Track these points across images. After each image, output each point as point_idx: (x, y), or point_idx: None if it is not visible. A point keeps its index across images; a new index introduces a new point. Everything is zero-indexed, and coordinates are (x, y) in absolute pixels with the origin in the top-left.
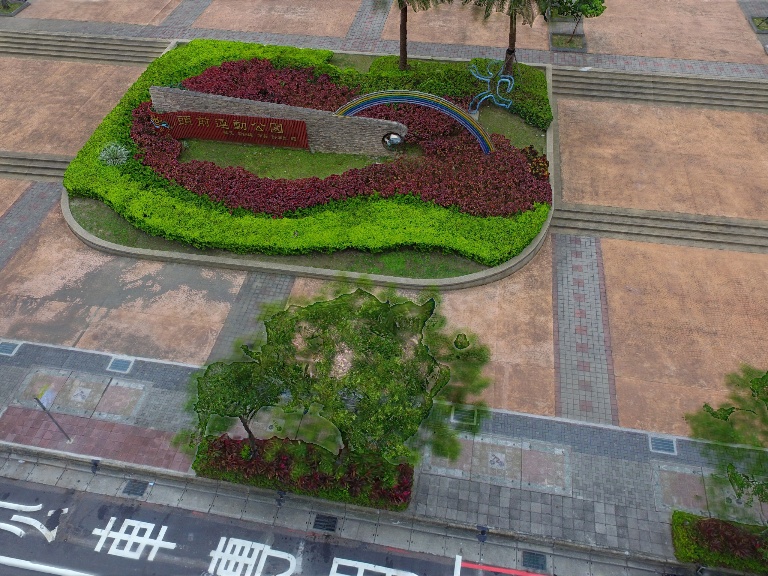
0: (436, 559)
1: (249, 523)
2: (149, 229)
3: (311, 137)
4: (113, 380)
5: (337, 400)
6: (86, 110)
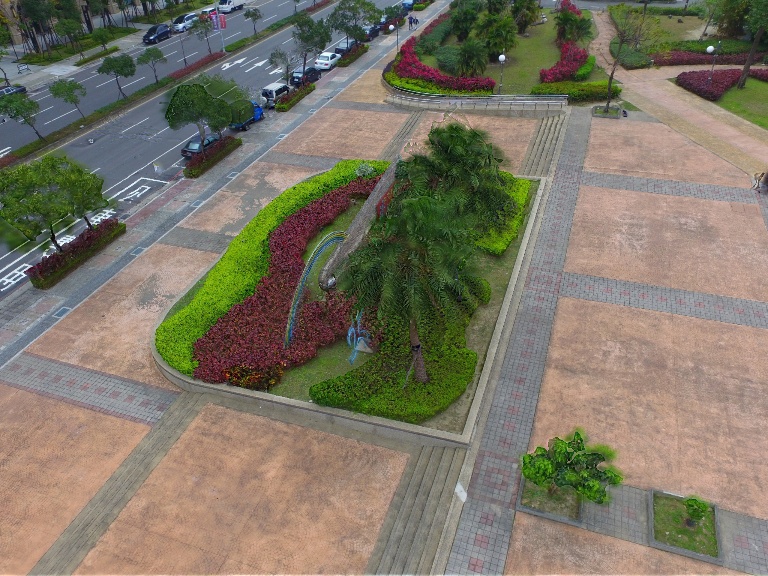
0: (4, 297)
1: None
2: None
3: None
4: None
5: (7, 172)
6: None
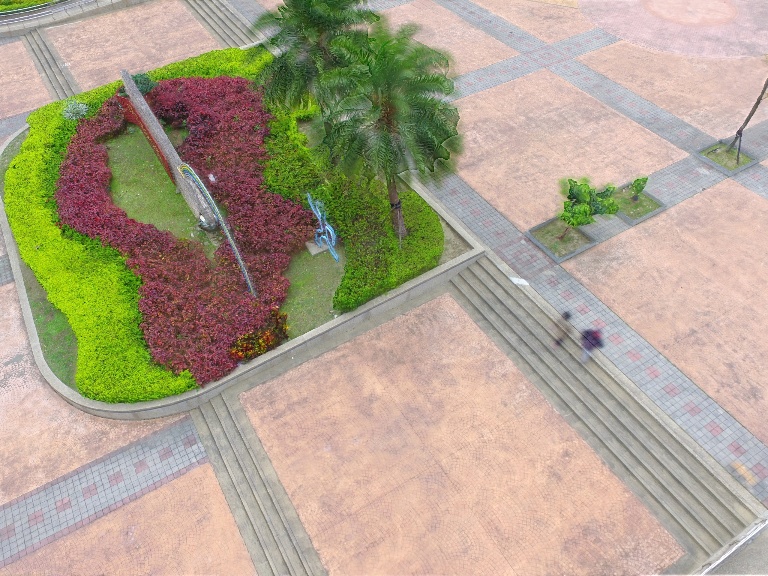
0: None
1: None
2: None
3: None
4: None
5: None
6: (147, 68)
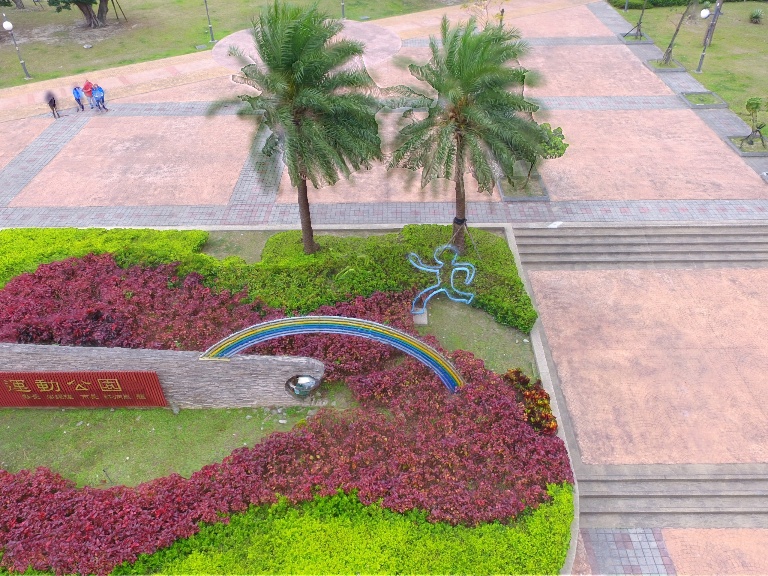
0: None
1: None
2: None
3: (170, 390)
4: None
5: None
6: None
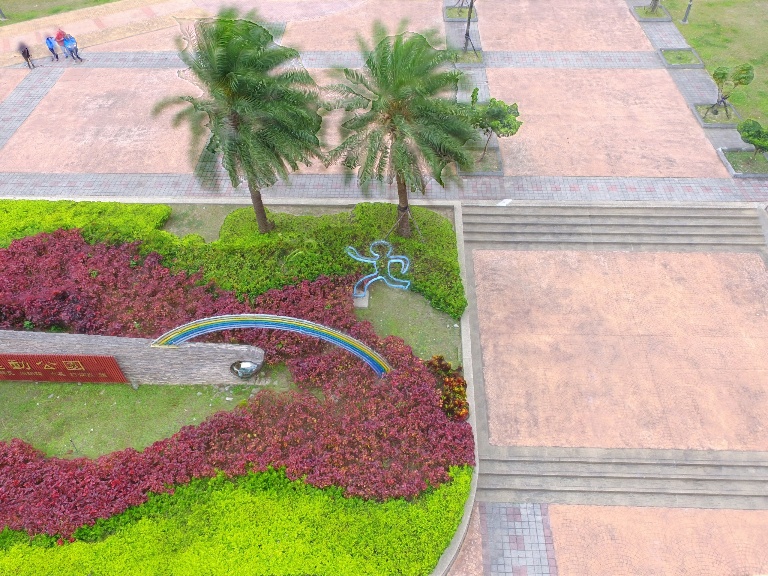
0: None
1: None
2: None
3: (128, 370)
4: None
5: None
6: None
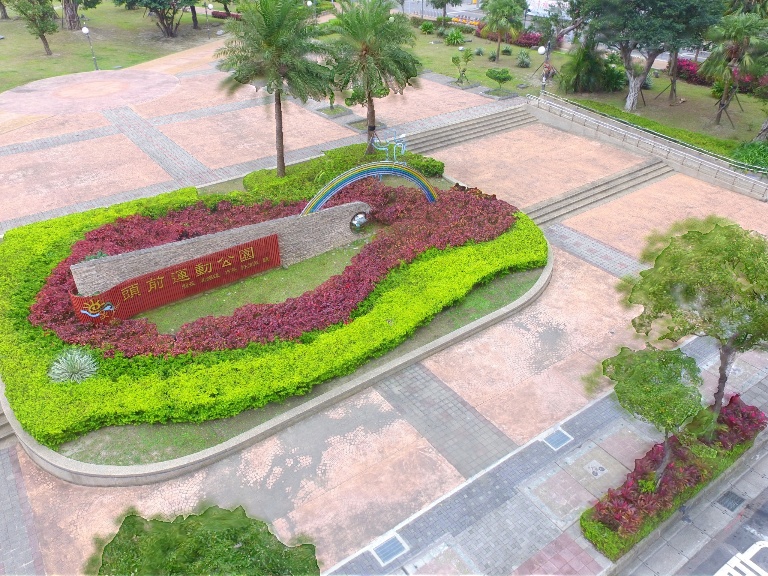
0: None
1: (700, 555)
2: (229, 409)
3: (281, 251)
4: (406, 568)
5: None
6: None
